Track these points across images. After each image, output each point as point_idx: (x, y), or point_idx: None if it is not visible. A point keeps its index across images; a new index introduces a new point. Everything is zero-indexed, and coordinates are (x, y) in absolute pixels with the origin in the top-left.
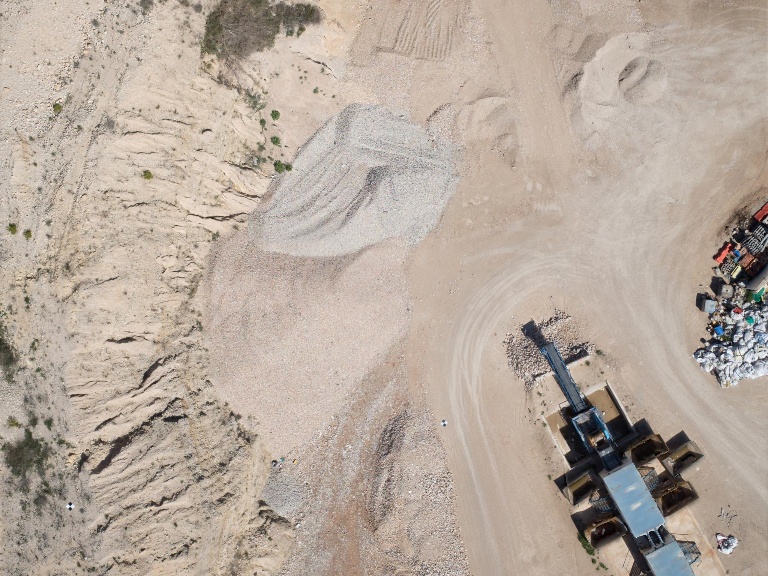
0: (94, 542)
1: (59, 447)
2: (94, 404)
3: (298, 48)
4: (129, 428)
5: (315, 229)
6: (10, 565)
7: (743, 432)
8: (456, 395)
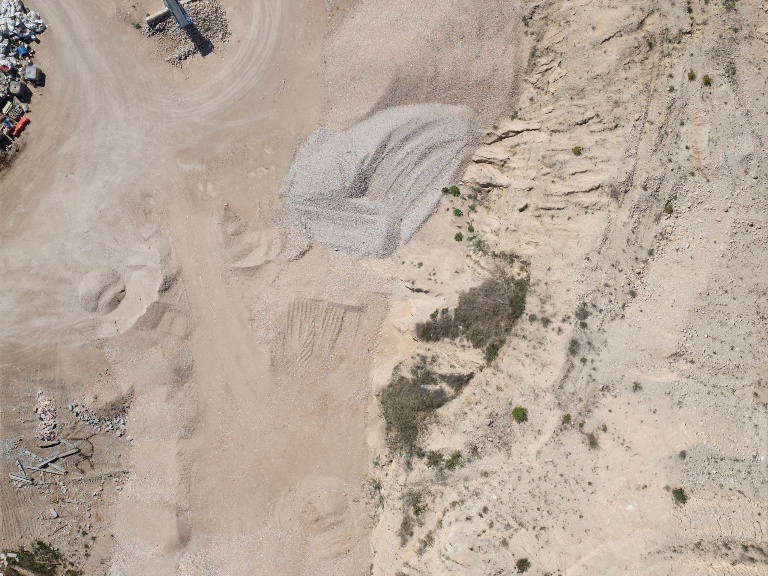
0: None
1: None
2: None
3: (437, 301)
4: None
5: (417, 130)
6: None
7: None
8: None
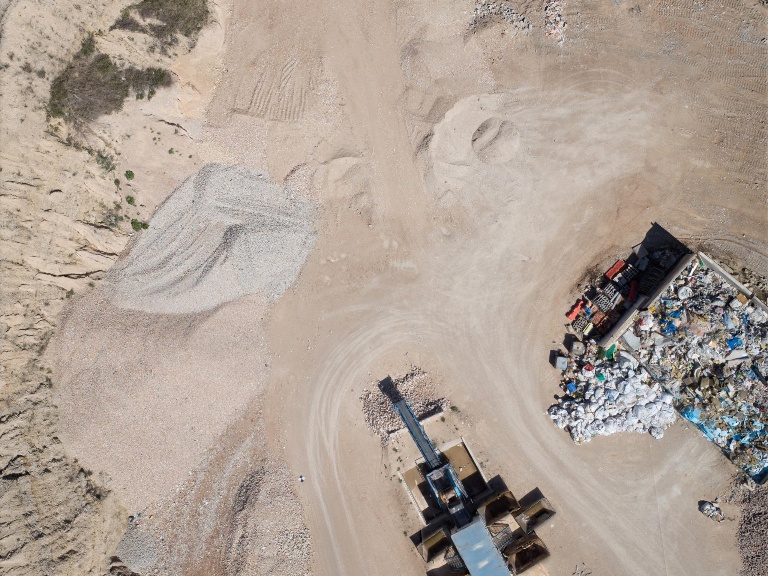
0: None
1: None
2: None
3: (150, 110)
4: None
5: (170, 286)
6: None
7: (597, 489)
8: (313, 451)
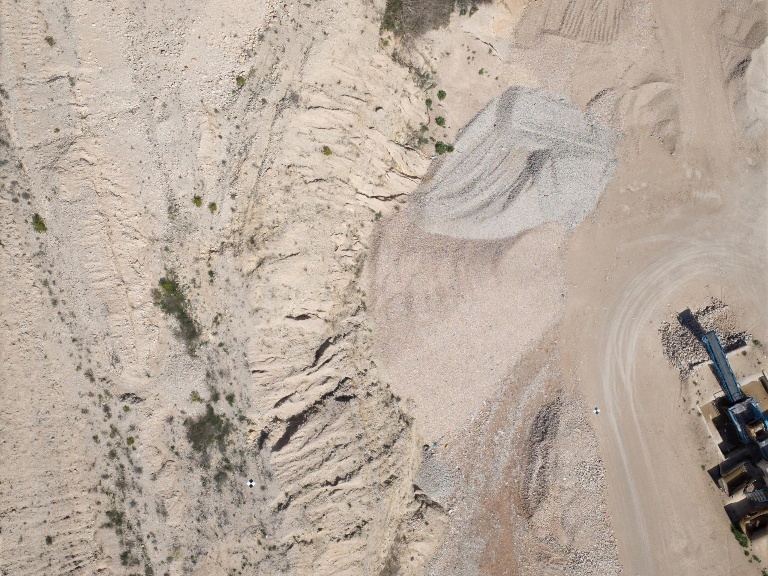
0: (275, 520)
1: (240, 423)
2: (273, 381)
3: (468, 28)
4: (303, 406)
5: (476, 211)
6: (190, 542)
7: None
8: (609, 383)
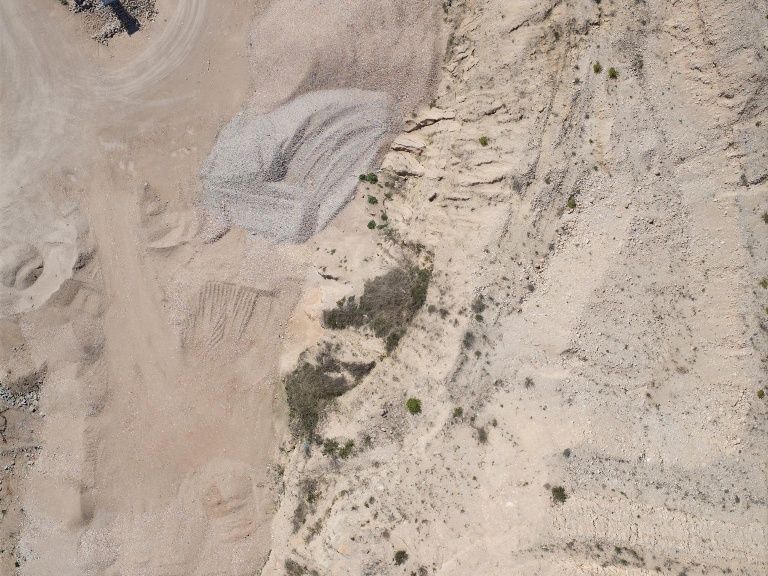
0: None
1: None
2: None
3: (346, 288)
4: None
5: (336, 115)
6: None
7: None
8: None
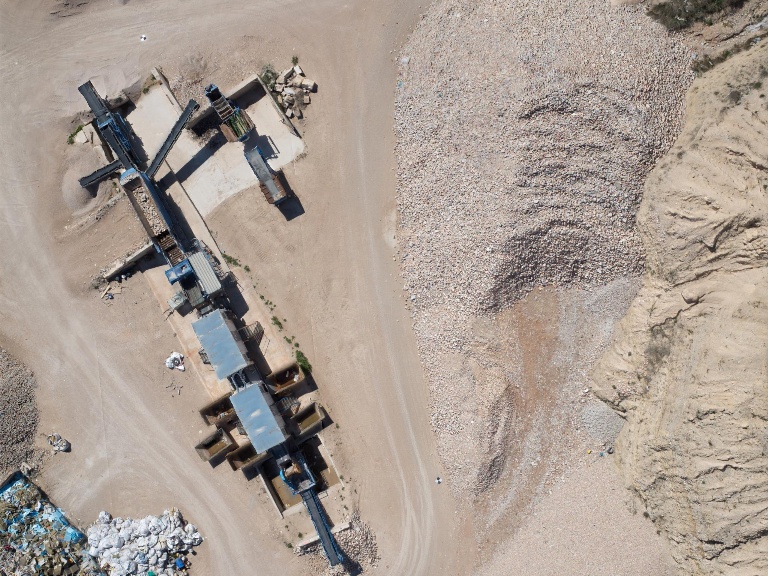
0: None
1: None
2: None
3: None
4: (761, 544)
5: None
6: None
7: (160, 465)
8: (427, 508)
